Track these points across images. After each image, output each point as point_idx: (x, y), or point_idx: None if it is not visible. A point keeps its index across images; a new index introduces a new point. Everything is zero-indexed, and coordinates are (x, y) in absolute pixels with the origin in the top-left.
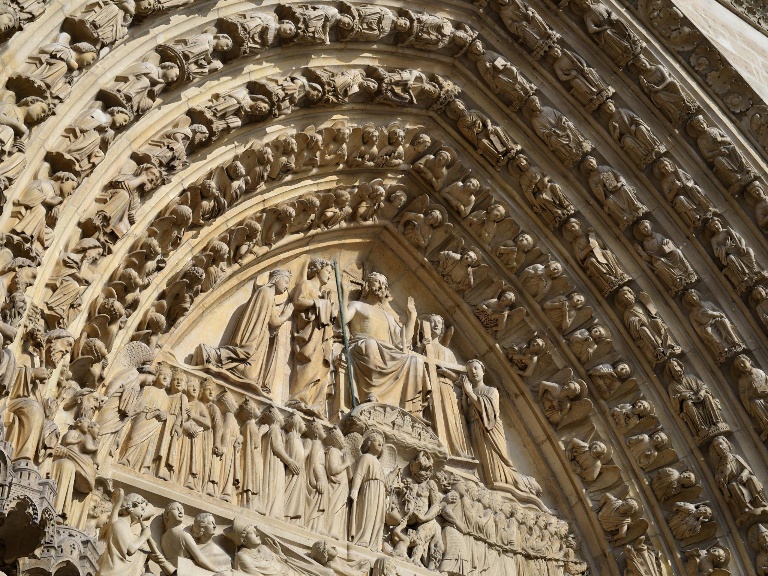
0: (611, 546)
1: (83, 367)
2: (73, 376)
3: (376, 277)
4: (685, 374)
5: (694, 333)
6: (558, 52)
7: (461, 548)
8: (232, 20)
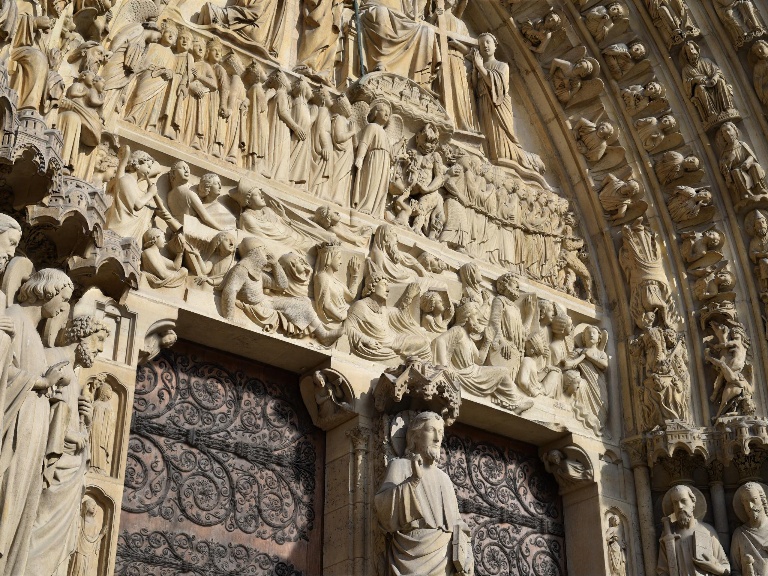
0: (609, 225)
1: (87, 19)
2: (77, 28)
3: None
4: (701, 57)
5: (715, 15)
6: None
7: (462, 220)
8: None
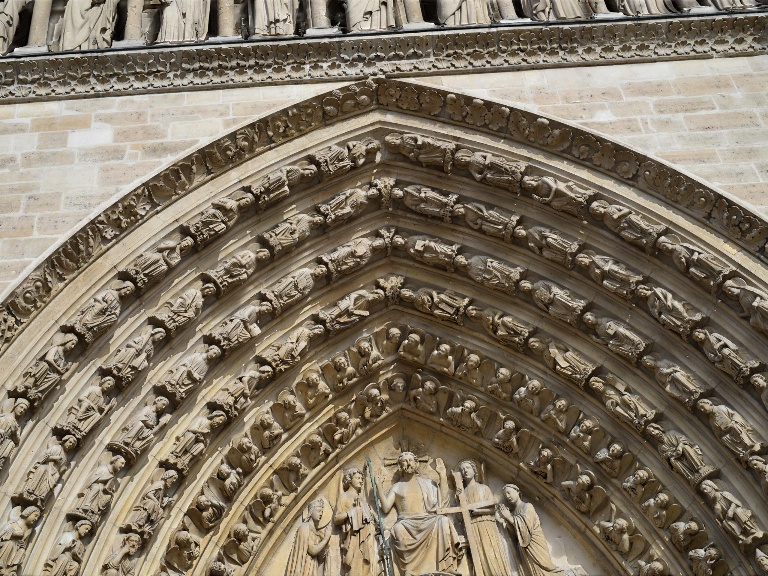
0: None
1: None
2: None
3: (403, 458)
4: (666, 433)
5: (663, 392)
6: (460, 211)
7: None
8: (161, 383)
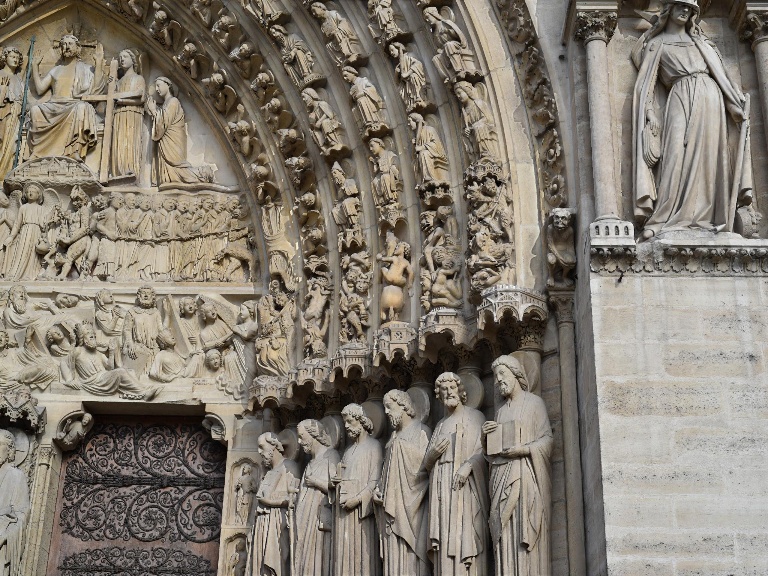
0: None
1: None
2: None
3: (64, 41)
4: (288, 36)
5: None
6: None
7: (108, 254)
8: None
